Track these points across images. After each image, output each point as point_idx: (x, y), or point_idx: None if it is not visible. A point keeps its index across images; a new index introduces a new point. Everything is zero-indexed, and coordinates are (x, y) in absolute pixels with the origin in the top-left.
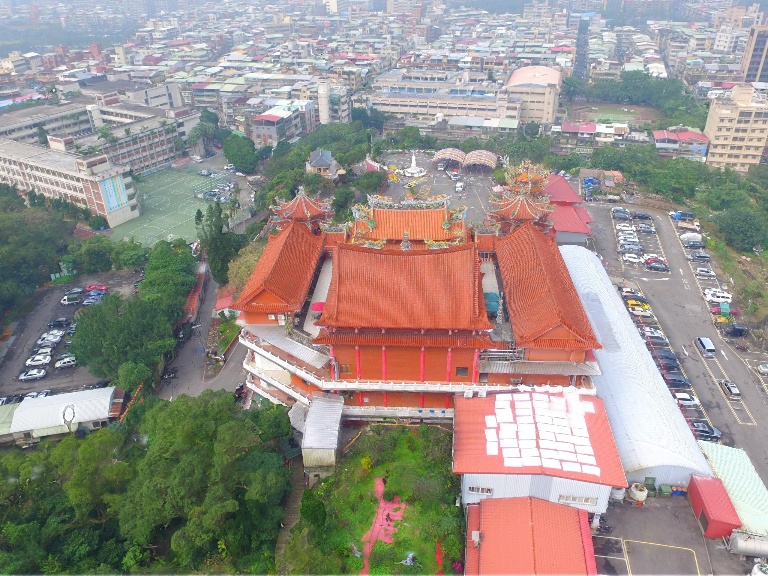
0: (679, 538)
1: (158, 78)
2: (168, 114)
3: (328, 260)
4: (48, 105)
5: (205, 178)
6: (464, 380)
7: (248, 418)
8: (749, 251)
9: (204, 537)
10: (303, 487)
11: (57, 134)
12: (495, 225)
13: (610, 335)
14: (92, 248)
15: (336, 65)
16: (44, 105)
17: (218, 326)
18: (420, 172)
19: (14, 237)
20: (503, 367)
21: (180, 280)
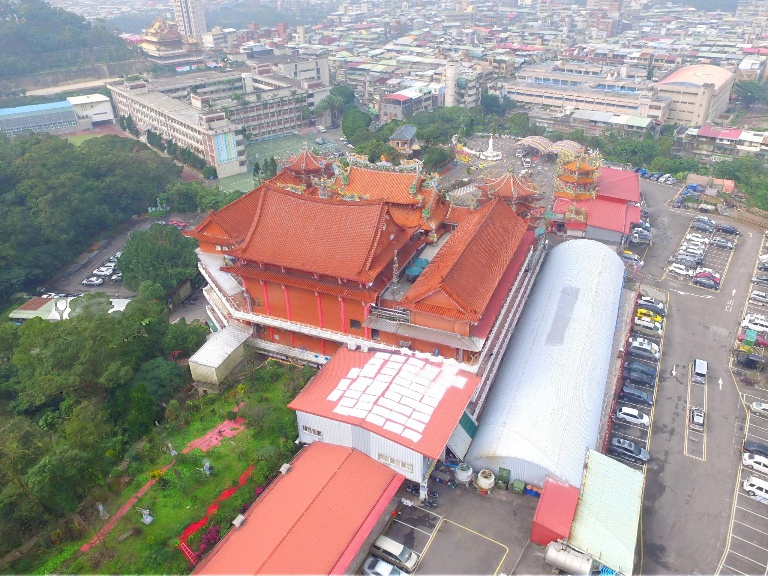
0: (502, 533)
1: (324, 56)
2: (303, 85)
3: None
4: (214, 71)
5: None
6: (358, 334)
7: None
8: None
9: (42, 398)
10: None
11: (199, 93)
12: None
13: (561, 329)
14: (182, 189)
15: (494, 54)
16: (211, 71)
17: None
18: (496, 156)
19: (120, 170)
20: (388, 326)
21: None
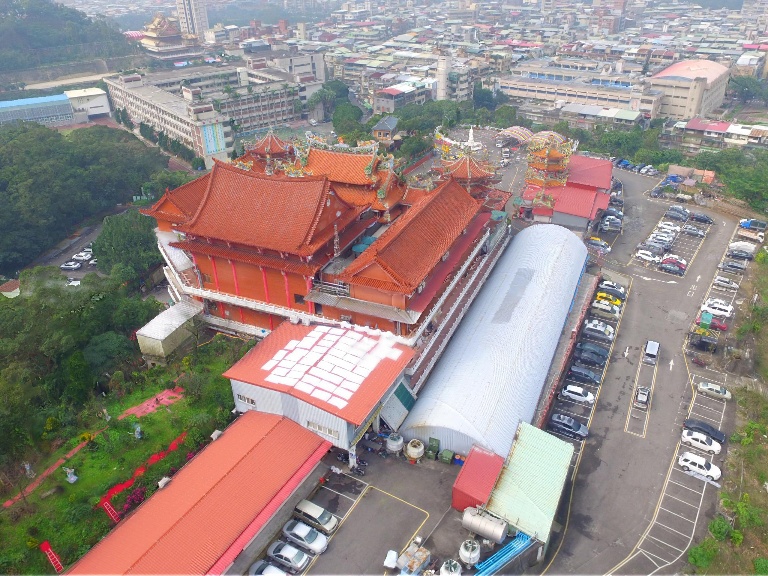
0: (425, 500)
1: (323, 52)
2: (295, 79)
3: None
4: (210, 66)
5: None
6: (302, 309)
7: None
8: None
9: None
10: None
11: (190, 86)
12: (427, 180)
13: (509, 308)
14: (165, 178)
15: (492, 50)
16: (208, 66)
17: None
18: (477, 146)
19: (104, 159)
20: (328, 299)
21: None
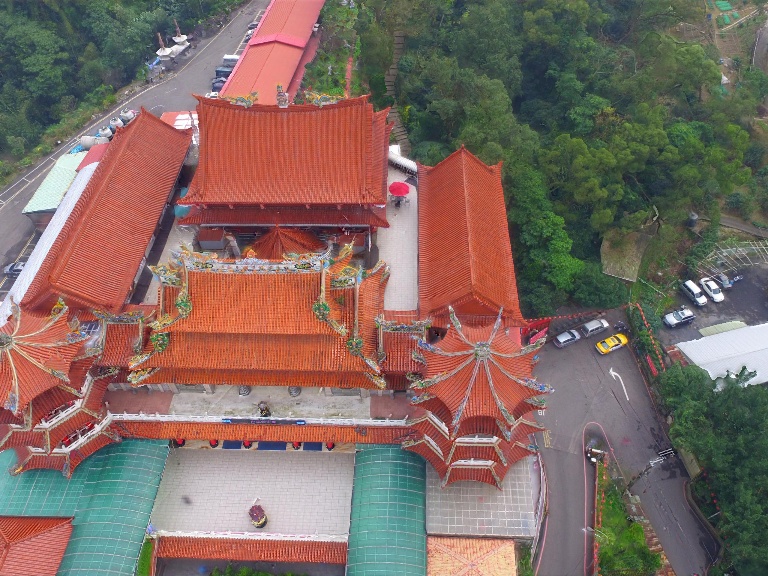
0: None
1: None
2: None
3: None
4: None
5: None
6: None
7: None
8: None
9: None
10: None
11: None
12: None
13: None
14: None
15: None
16: None
17: None
18: None
19: None
20: None
21: None
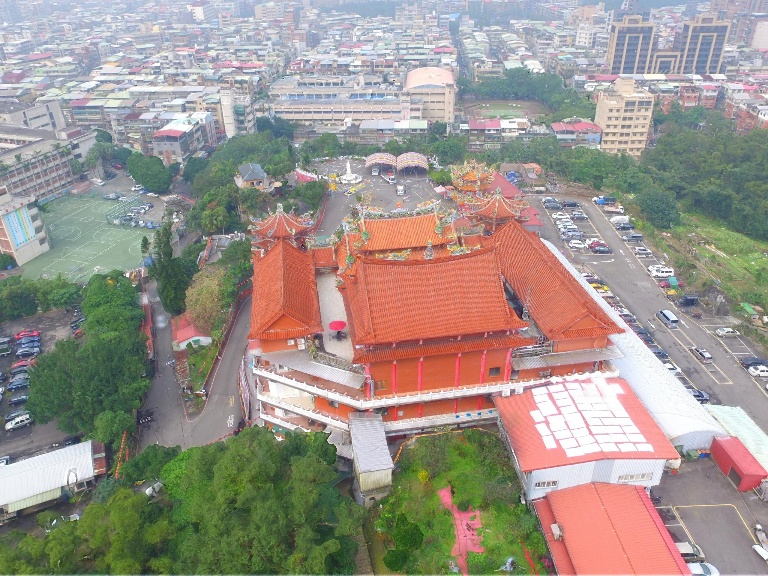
0: (718, 496)
1: (26, 97)
2: (59, 136)
3: (319, 277)
4: None
5: (113, 202)
6: (496, 380)
7: (289, 451)
8: (668, 228)
9: None
10: None
11: None
12: (480, 225)
13: None
14: (14, 291)
15: (224, 74)
16: None
17: (185, 359)
18: (356, 178)
19: None
20: (535, 362)
21: (130, 315)
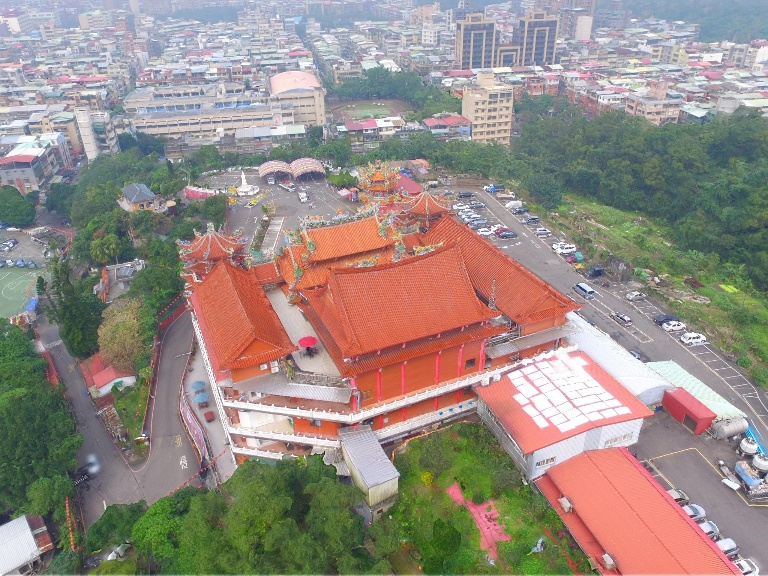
0: (681, 443)
1: None
2: None
3: None
4: None
5: None
6: (472, 371)
7: (287, 481)
8: (555, 208)
9: None
10: (364, 529)
11: None
12: (415, 223)
13: None
14: None
15: (64, 90)
16: None
17: (109, 405)
18: (252, 190)
19: None
20: (507, 348)
21: (31, 366)
